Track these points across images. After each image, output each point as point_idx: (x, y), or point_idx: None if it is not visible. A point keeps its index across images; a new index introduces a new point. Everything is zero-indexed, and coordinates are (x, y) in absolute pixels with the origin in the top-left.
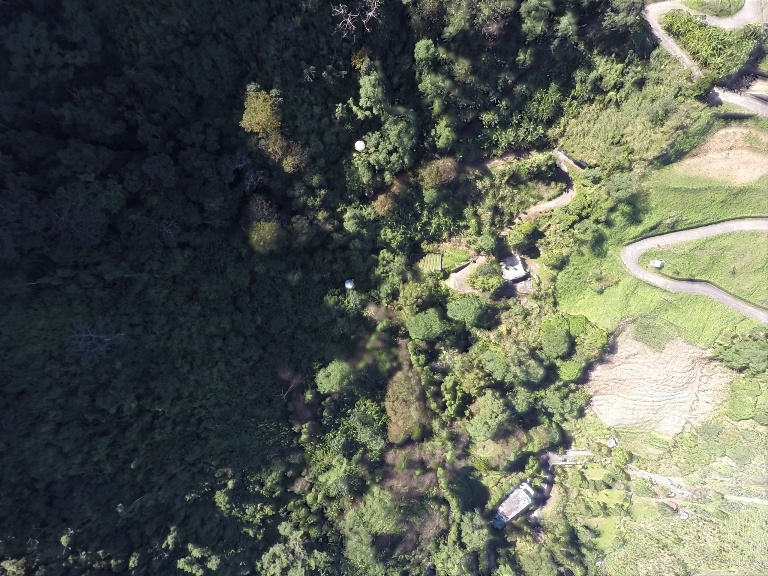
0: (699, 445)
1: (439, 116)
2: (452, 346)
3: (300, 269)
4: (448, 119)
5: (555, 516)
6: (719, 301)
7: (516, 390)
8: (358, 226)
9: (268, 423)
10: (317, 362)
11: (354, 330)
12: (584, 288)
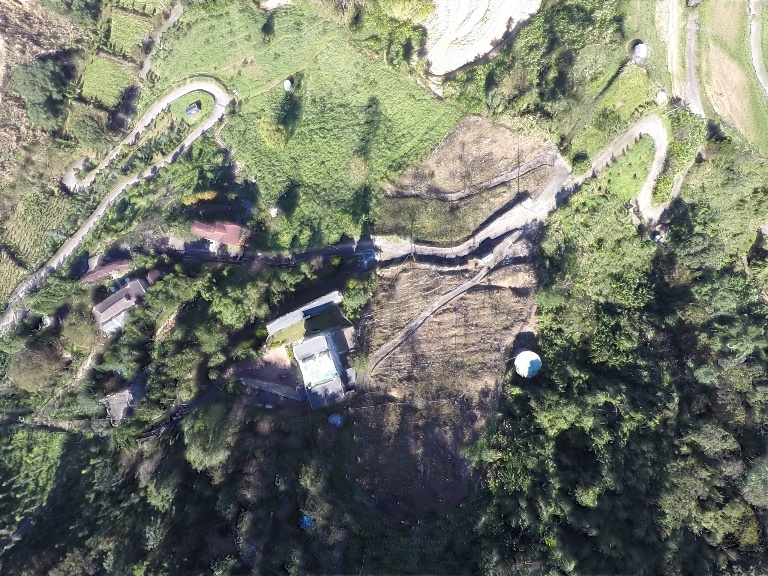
0: None
1: None
2: None
3: None
4: None
5: None
6: None
7: None
8: None
9: None
10: None
11: None
12: None
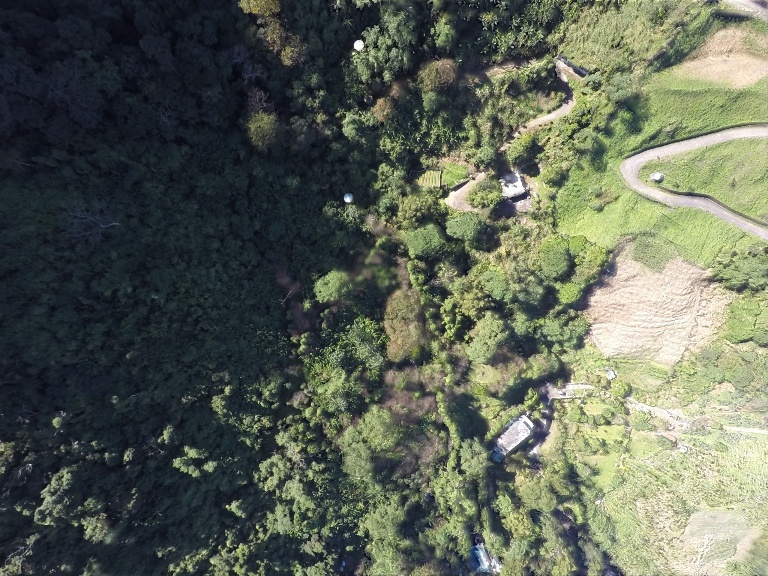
0: (698, 372)
1: (438, 14)
2: (451, 268)
3: (299, 177)
4: (447, 18)
5: (554, 453)
6: (719, 217)
7: (515, 314)
8: (357, 134)
9: (267, 331)
10: (316, 273)
11: (353, 245)
12: (584, 207)
